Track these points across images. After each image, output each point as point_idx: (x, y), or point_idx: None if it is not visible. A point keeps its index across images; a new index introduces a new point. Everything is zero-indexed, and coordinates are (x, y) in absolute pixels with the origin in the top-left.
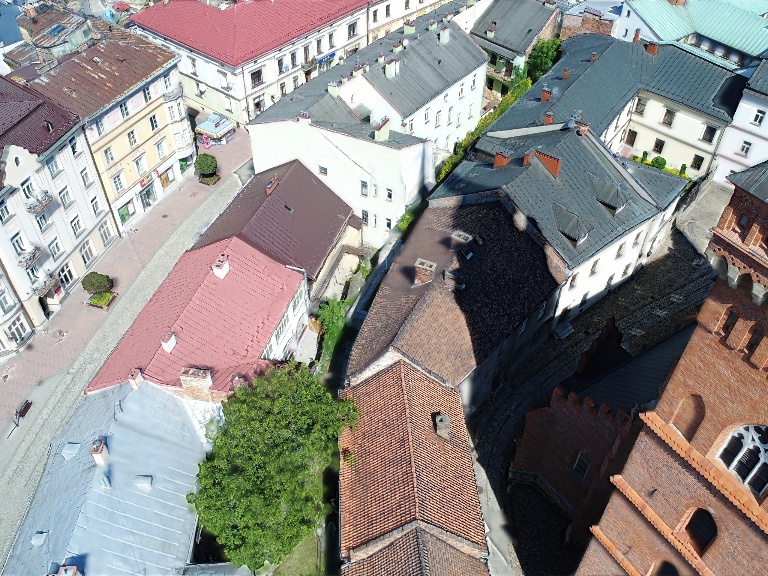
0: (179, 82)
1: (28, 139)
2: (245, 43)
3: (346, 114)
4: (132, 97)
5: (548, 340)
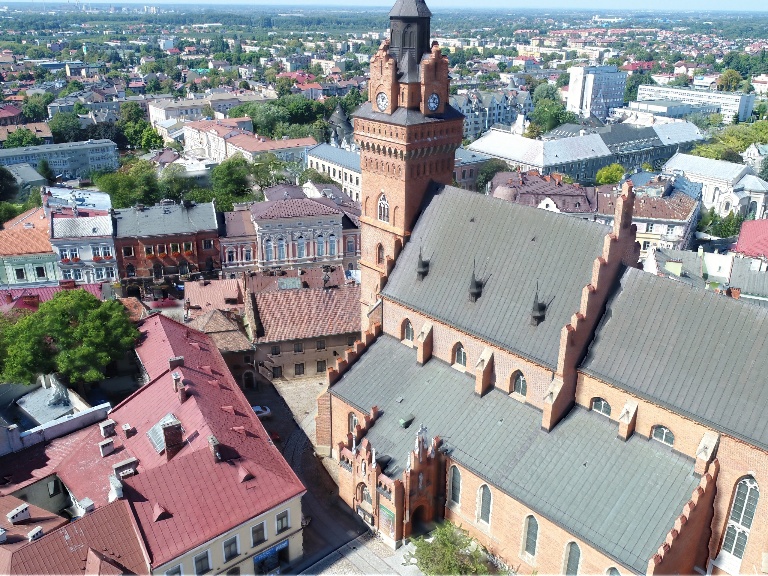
0: (679, 235)
1: (563, 203)
2: (761, 248)
3: (696, 267)
4: (637, 222)
5: None
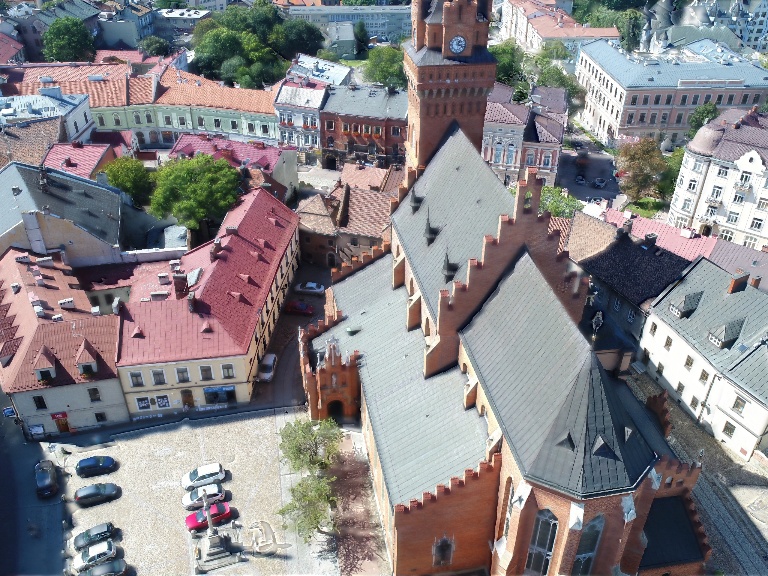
0: None
1: None
2: None
3: None
4: None
5: (632, 359)
